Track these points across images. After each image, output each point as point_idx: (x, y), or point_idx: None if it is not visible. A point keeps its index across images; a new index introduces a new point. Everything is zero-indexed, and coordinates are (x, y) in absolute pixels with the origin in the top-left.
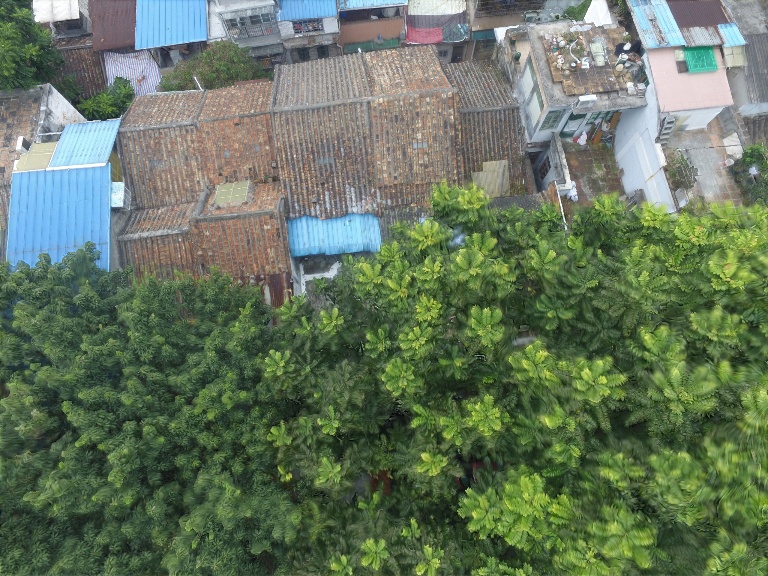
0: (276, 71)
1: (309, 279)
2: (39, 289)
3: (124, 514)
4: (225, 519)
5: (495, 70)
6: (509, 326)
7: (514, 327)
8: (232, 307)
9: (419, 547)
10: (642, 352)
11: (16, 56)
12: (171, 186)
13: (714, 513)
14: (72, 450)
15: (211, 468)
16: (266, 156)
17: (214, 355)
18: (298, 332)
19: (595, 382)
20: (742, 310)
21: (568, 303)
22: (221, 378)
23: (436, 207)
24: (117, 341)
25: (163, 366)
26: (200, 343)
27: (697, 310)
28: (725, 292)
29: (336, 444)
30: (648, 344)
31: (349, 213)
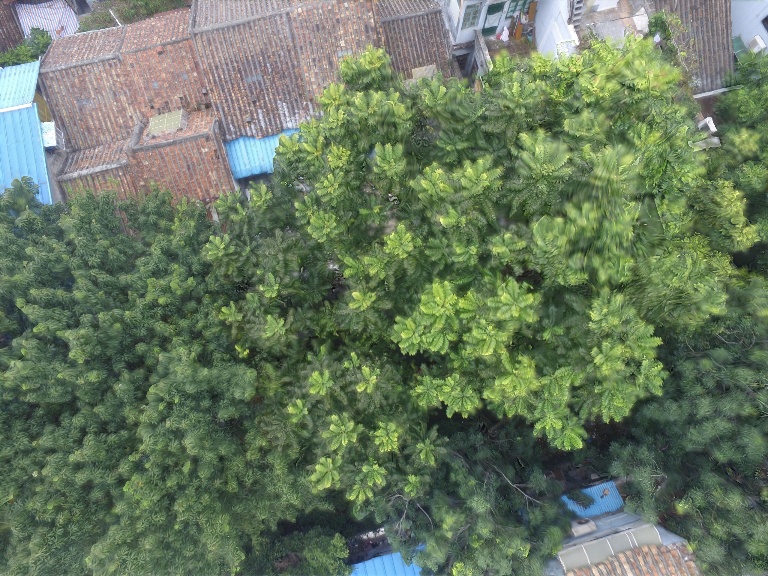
0: None
1: None
2: None
3: (96, 401)
4: (187, 384)
5: None
6: (413, 162)
7: None
8: None
9: (359, 372)
10: (517, 151)
11: None
12: (104, 124)
13: (580, 268)
14: (32, 340)
15: (171, 351)
16: (195, 83)
17: (160, 253)
18: (235, 218)
19: (478, 180)
20: (611, 117)
21: (464, 136)
22: (170, 275)
23: (345, 77)
24: (62, 247)
25: (114, 273)
26: (147, 250)
27: (569, 118)
28: (595, 103)
29: None
30: (520, 141)
31: (285, 129)
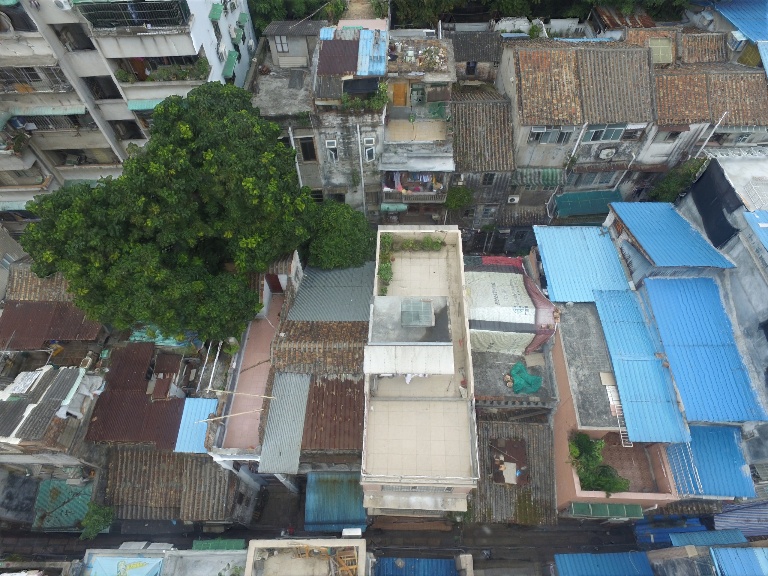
0: None
1: None
2: None
3: None
4: None
5: (455, 154)
6: None
7: None
8: None
9: None
10: None
11: None
12: None
13: None
14: None
15: None
16: None
17: None
18: None
19: None
20: None
21: None
22: None
23: None
24: None
25: None
26: None
27: None
28: None
29: None
30: None
31: None
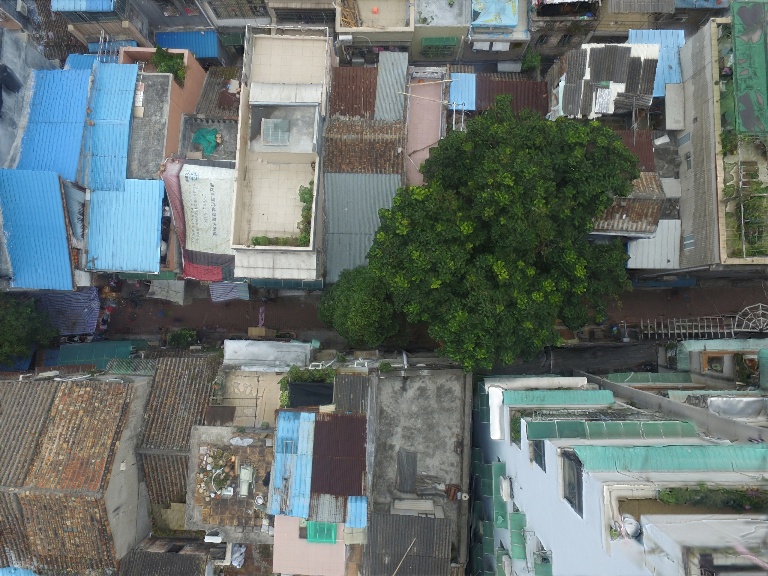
0: None
1: None
2: None
3: None
4: None
5: None
6: None
7: None
8: None
9: None
10: None
11: None
12: None
13: None
14: None
15: None
16: None
17: None
18: None
19: None
20: None
21: None
22: None
23: None
24: None
25: None
26: None
27: None
28: None
29: None
30: None
31: None
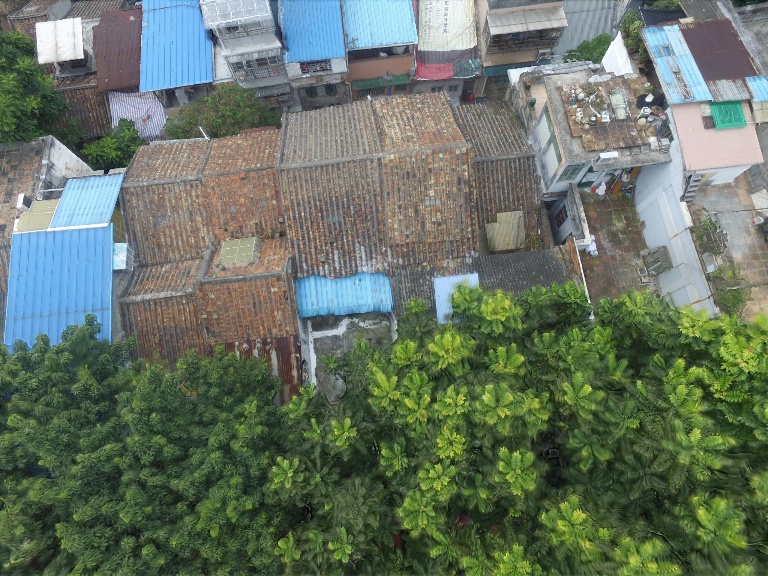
0: (283, 121)
1: (317, 336)
2: (35, 380)
3: None
4: None
5: (509, 113)
6: (540, 465)
7: (543, 453)
8: (237, 388)
9: None
10: (695, 526)
11: (17, 111)
12: (175, 242)
13: None
14: None
15: None
16: (273, 211)
17: (218, 456)
18: (307, 436)
19: (643, 564)
20: None
21: (605, 439)
22: (226, 479)
23: (456, 309)
24: (116, 445)
25: (165, 462)
26: (204, 434)
27: (753, 464)
28: None
29: (348, 563)
30: (703, 520)
31: (359, 272)
